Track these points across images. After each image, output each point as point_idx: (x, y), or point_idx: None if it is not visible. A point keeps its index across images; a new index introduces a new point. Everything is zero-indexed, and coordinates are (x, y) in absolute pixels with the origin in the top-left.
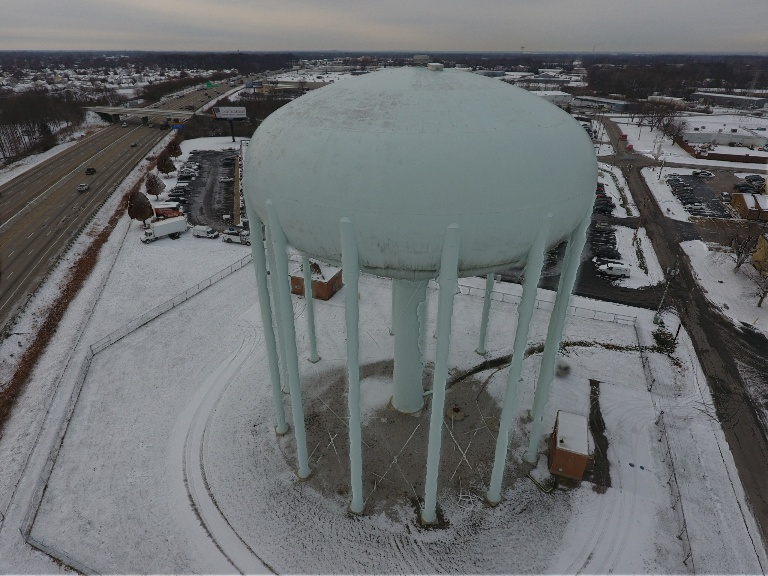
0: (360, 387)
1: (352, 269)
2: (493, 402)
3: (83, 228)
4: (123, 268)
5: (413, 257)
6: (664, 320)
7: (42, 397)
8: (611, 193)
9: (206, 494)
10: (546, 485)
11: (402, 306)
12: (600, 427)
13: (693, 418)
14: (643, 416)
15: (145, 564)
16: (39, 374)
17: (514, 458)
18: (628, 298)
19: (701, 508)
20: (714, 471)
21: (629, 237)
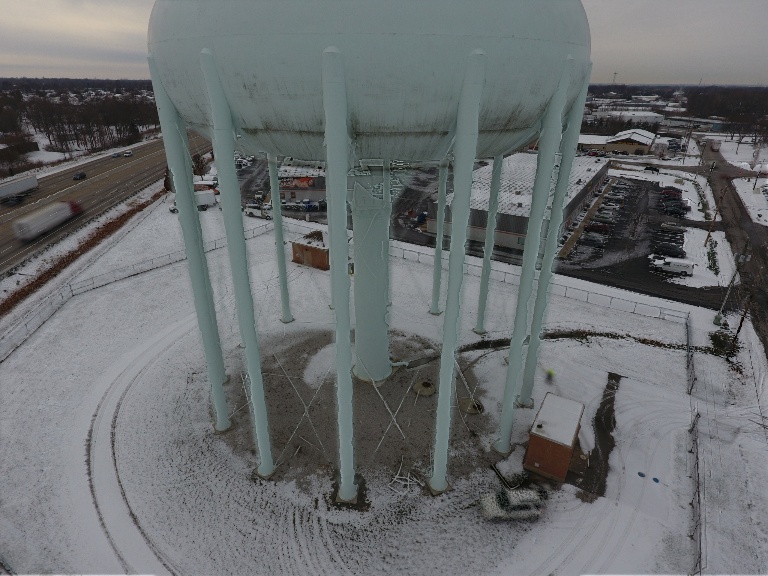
0: (324, 350)
1: (221, 126)
2: (475, 382)
3: (125, 199)
4: (142, 230)
5: (289, 105)
6: (729, 322)
7: (6, 325)
8: (689, 198)
9: (108, 432)
10: (513, 481)
11: (357, 242)
12: (608, 425)
13: (747, 432)
14: (673, 420)
15: (6, 491)
16: (19, 308)
17: (481, 445)
18: (685, 296)
19: (736, 544)
20: (767, 500)
21: (702, 239)
